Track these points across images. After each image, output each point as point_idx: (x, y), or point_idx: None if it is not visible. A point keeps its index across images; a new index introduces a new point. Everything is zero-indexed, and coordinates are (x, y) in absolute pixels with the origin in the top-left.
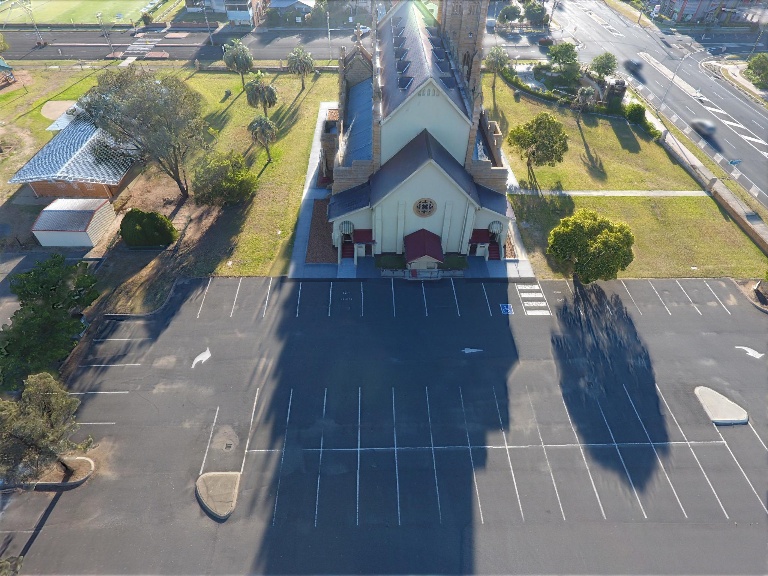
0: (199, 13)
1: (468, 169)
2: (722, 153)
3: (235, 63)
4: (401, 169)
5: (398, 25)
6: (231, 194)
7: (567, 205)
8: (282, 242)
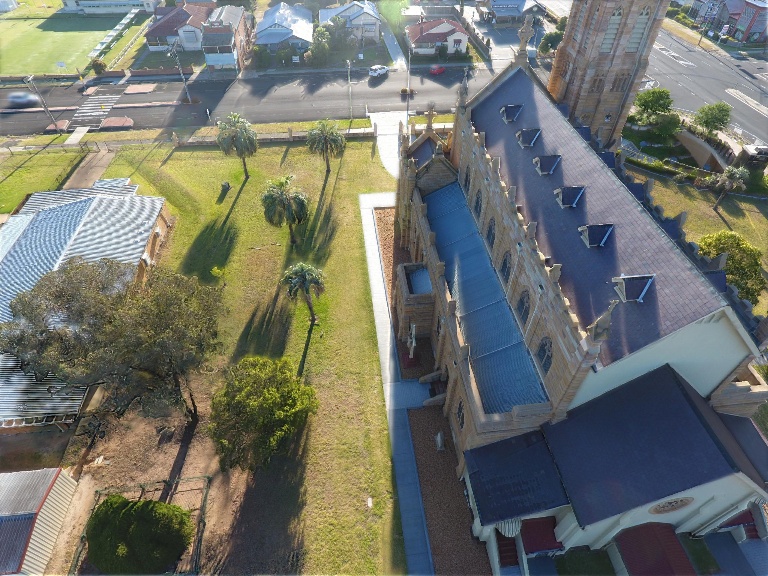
0: (165, 52)
1: (713, 401)
2: None
3: (234, 146)
4: (639, 454)
5: (517, 118)
6: (282, 445)
7: None
8: (381, 531)
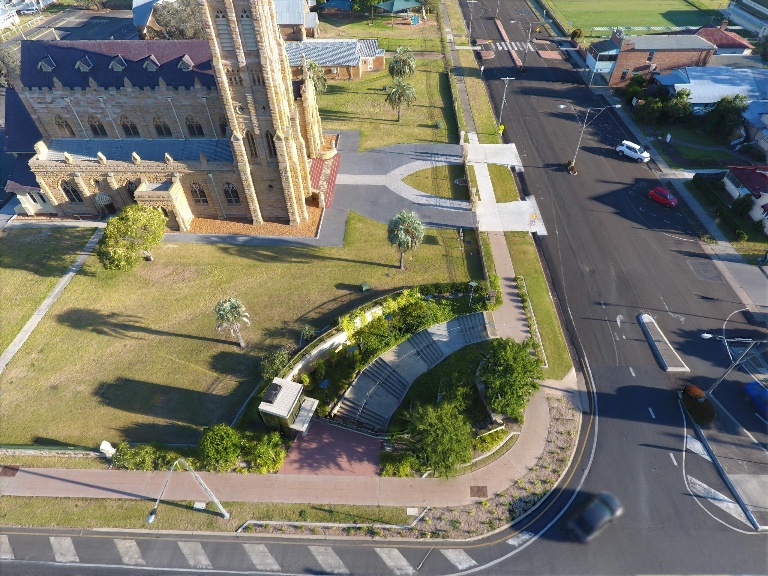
0: None
1: None
2: (5, 568)
3: None
4: None
5: None
6: None
7: (48, 270)
8: None
